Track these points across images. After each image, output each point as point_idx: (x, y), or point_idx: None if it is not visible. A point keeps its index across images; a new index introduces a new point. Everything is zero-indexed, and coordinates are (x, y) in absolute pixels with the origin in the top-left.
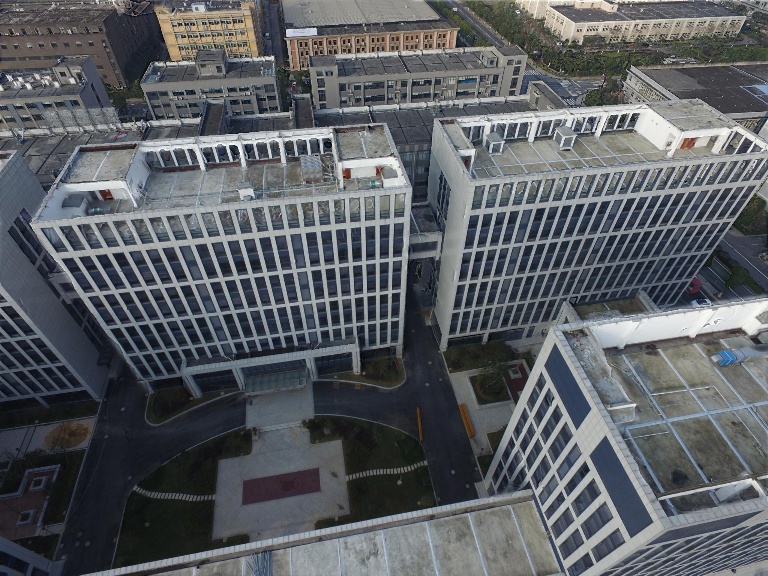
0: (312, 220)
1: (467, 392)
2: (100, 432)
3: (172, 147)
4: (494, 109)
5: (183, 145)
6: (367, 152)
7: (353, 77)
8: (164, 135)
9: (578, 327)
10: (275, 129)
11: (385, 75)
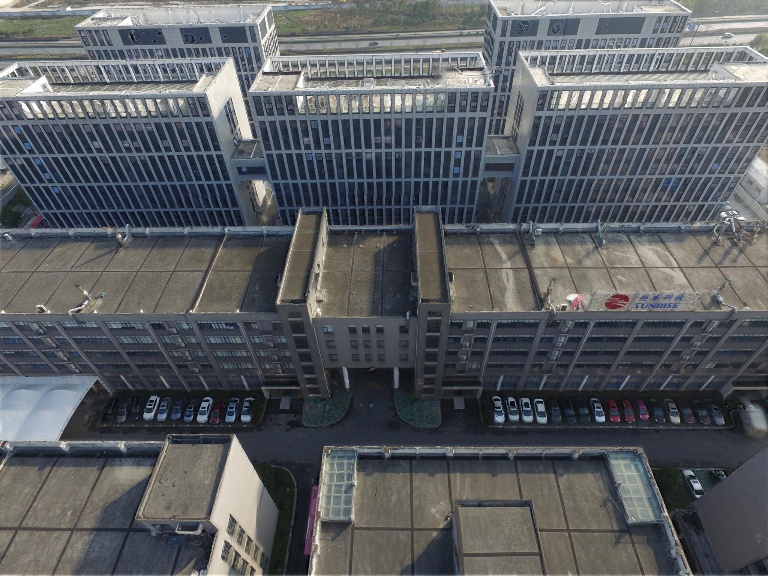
0: (331, 74)
1: (268, 184)
2: (485, 187)
3: (421, 86)
4: (2, 299)
5: (413, 86)
6: (279, 78)
7: (145, 443)
8: (510, 292)
9: (248, 22)
10: (348, 288)
11: (68, 443)
